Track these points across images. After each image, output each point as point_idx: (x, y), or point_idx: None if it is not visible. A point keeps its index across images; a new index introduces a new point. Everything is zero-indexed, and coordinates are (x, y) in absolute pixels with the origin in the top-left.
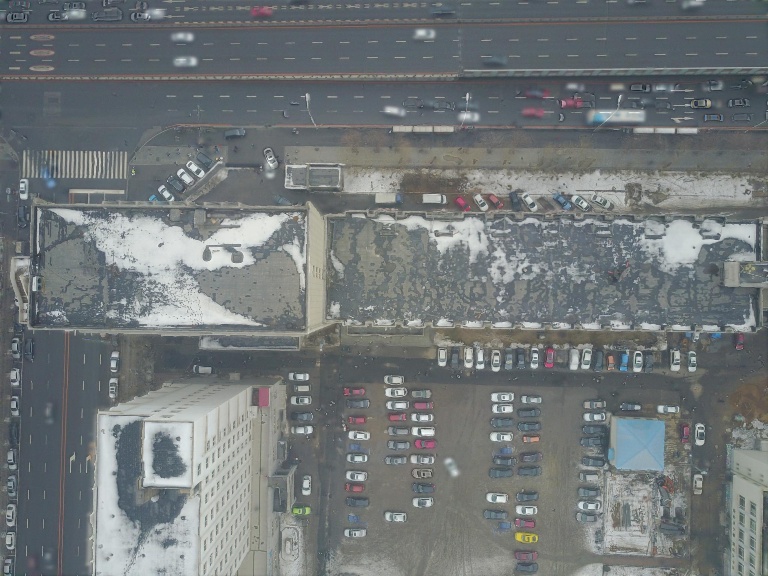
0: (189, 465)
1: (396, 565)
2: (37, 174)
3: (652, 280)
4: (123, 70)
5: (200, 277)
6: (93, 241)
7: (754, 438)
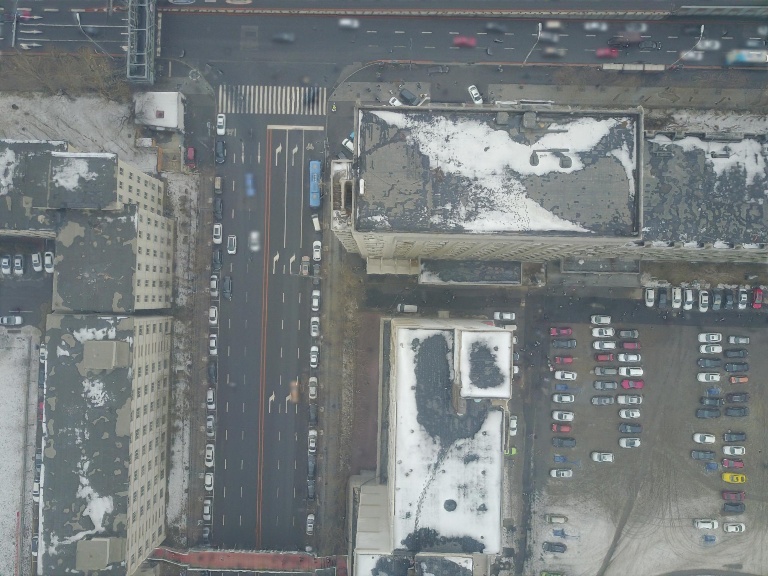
0: (507, 375)
1: (602, 506)
2: (233, 109)
3: None
4: (323, 4)
5: (528, 182)
6: (416, 145)
7: None
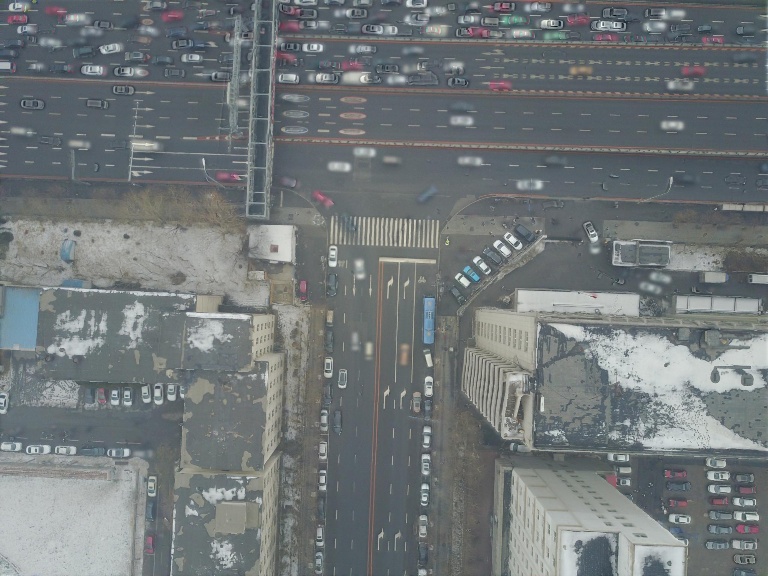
0: None
1: None
2: (345, 240)
3: None
4: (438, 136)
5: (708, 399)
6: (595, 358)
7: None
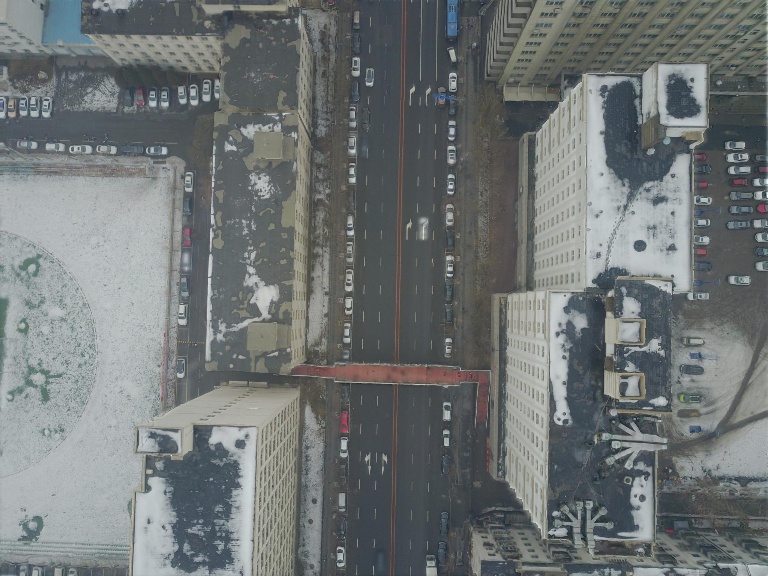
0: (704, 105)
1: (739, 329)
2: None
3: None
4: None
5: None
6: None
7: None
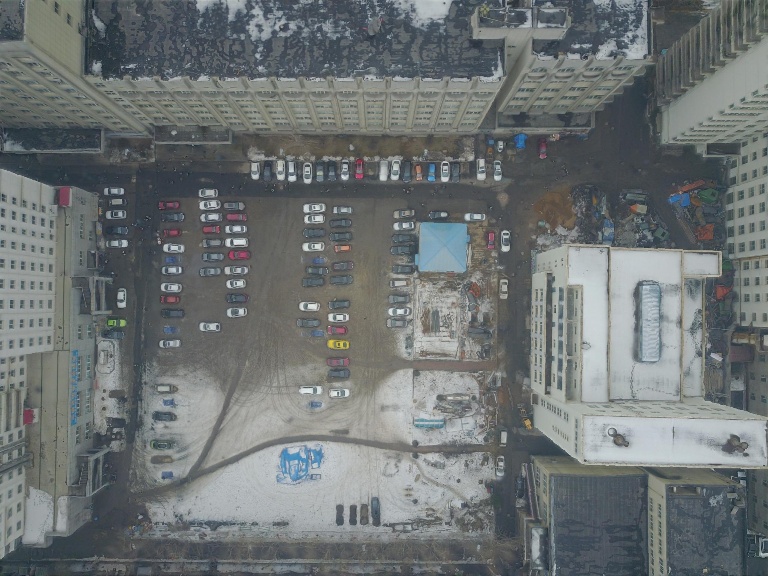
0: None
1: (211, 375)
2: None
3: (405, 35)
4: None
5: None
6: None
7: (558, 244)
